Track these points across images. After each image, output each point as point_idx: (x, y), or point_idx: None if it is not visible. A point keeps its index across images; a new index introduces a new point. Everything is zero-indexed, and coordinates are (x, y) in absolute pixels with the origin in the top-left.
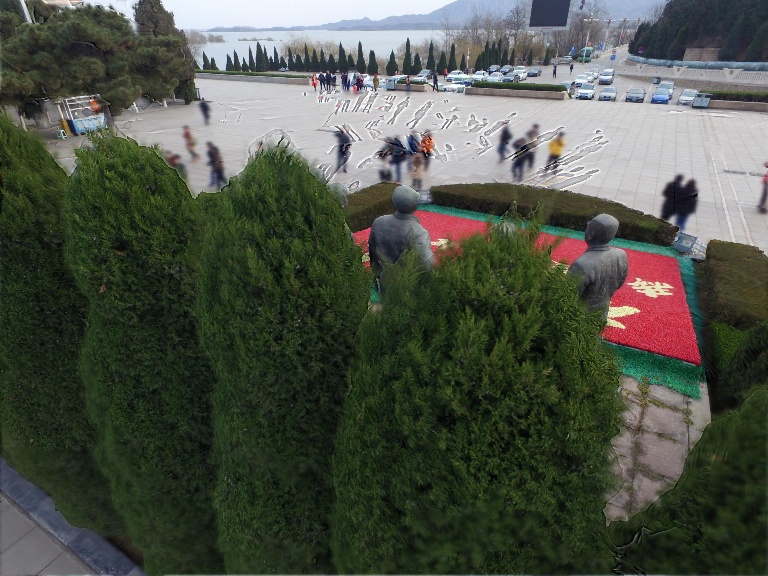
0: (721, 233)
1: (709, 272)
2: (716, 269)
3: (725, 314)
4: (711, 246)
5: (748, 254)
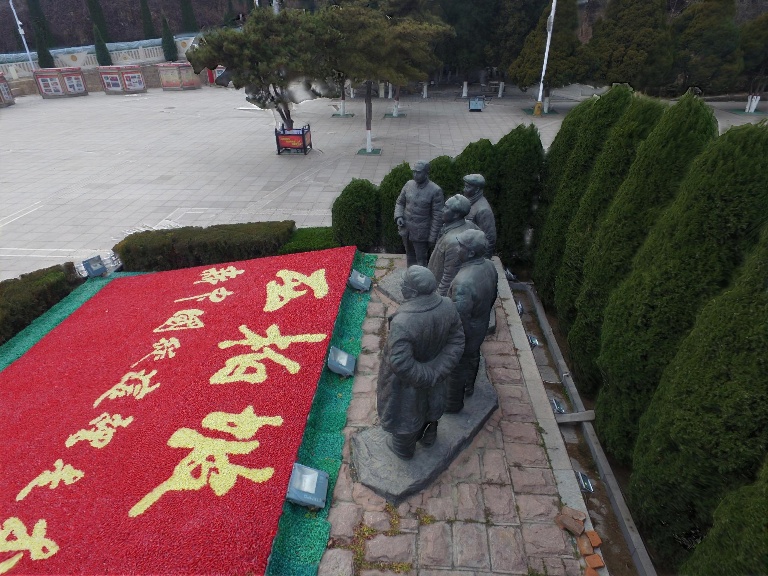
0: (39, 260)
1: (188, 251)
2: (199, 242)
3: (274, 243)
4: (135, 247)
5: (157, 234)
